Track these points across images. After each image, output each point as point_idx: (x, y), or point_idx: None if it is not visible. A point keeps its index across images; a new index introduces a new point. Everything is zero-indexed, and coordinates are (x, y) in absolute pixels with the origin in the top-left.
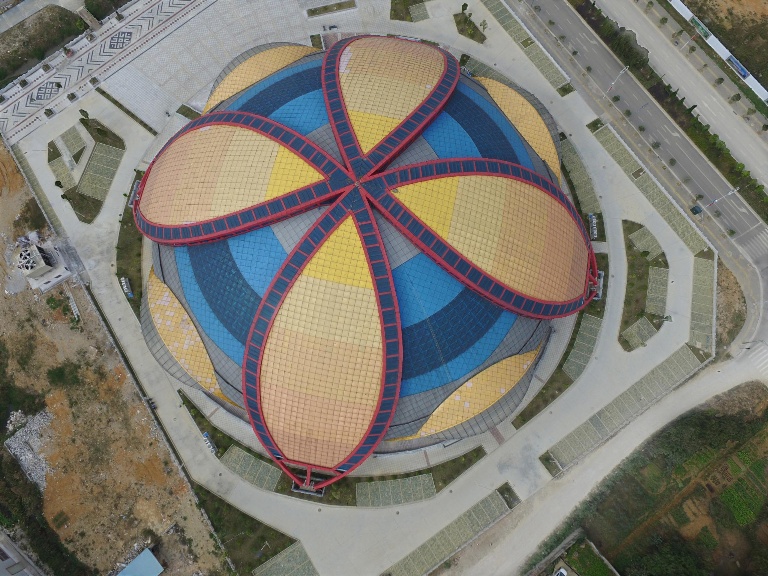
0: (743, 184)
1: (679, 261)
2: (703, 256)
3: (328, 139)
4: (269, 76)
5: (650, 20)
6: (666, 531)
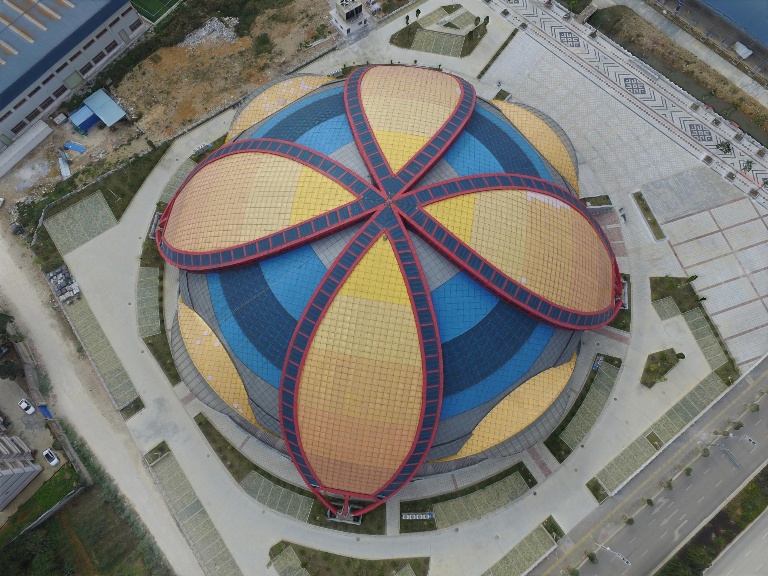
0: None
1: None
2: None
3: None
4: (530, 143)
5: None
6: None
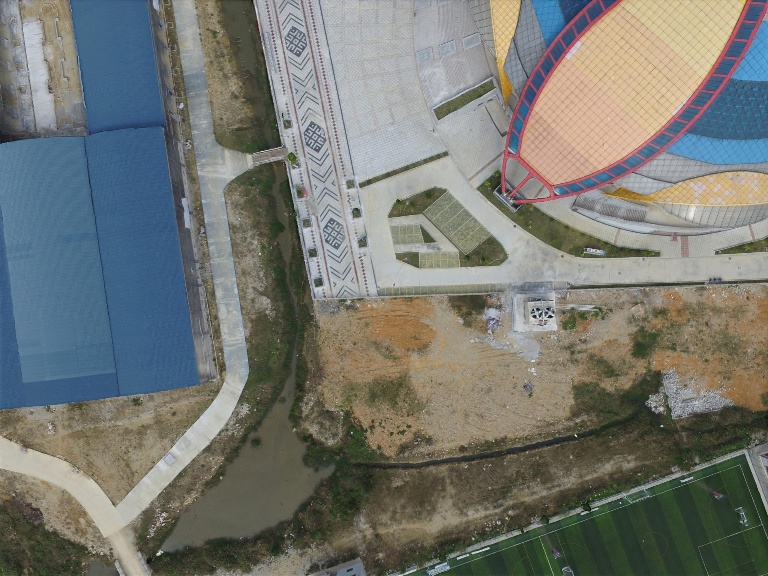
0: None
1: None
2: None
3: None
4: None
5: None
6: None
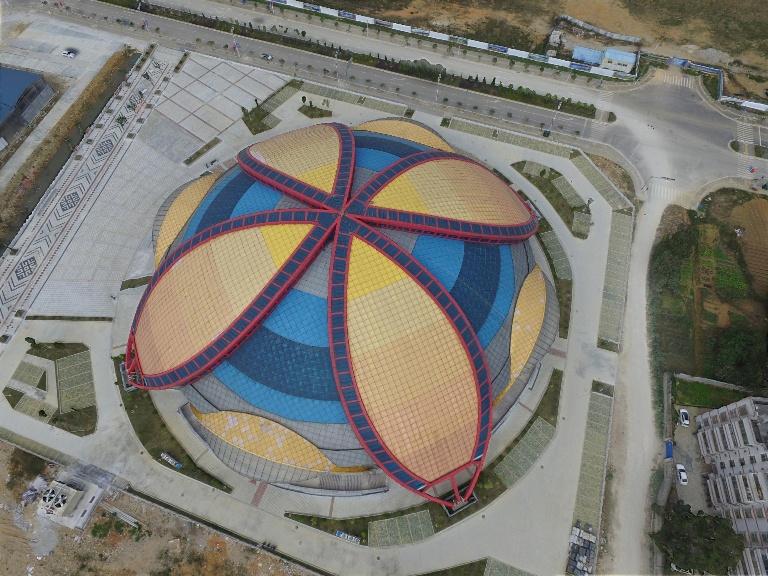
0: None
1: (564, 167)
2: (574, 156)
3: (292, 204)
4: (199, 205)
5: (426, 51)
6: (712, 333)
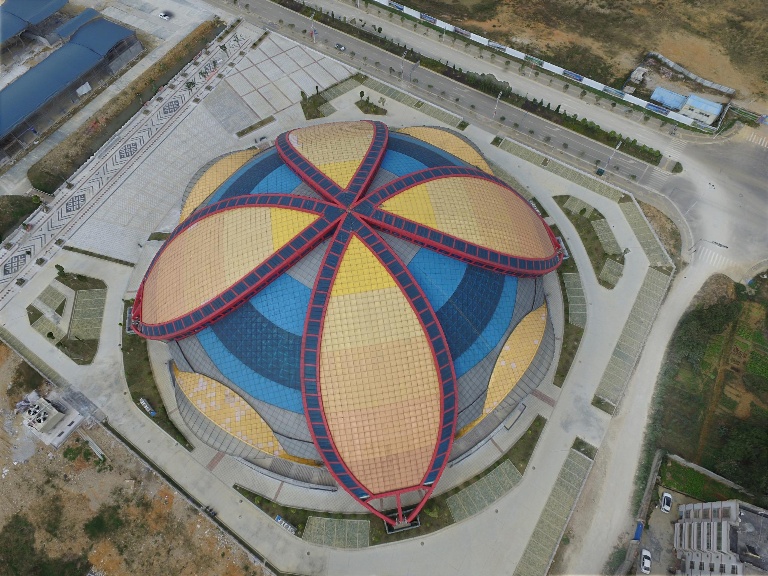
0: (621, 145)
1: (609, 210)
2: (624, 201)
3: (308, 192)
4: (231, 176)
5: (498, 66)
6: (725, 420)
